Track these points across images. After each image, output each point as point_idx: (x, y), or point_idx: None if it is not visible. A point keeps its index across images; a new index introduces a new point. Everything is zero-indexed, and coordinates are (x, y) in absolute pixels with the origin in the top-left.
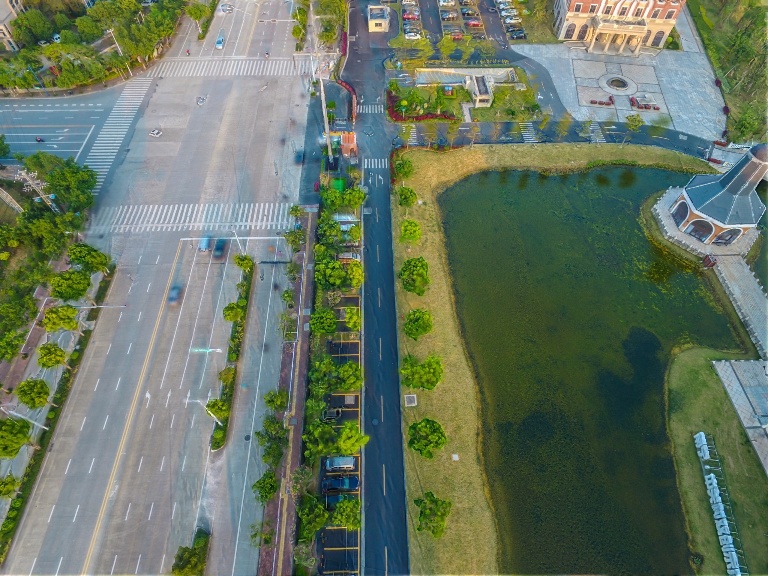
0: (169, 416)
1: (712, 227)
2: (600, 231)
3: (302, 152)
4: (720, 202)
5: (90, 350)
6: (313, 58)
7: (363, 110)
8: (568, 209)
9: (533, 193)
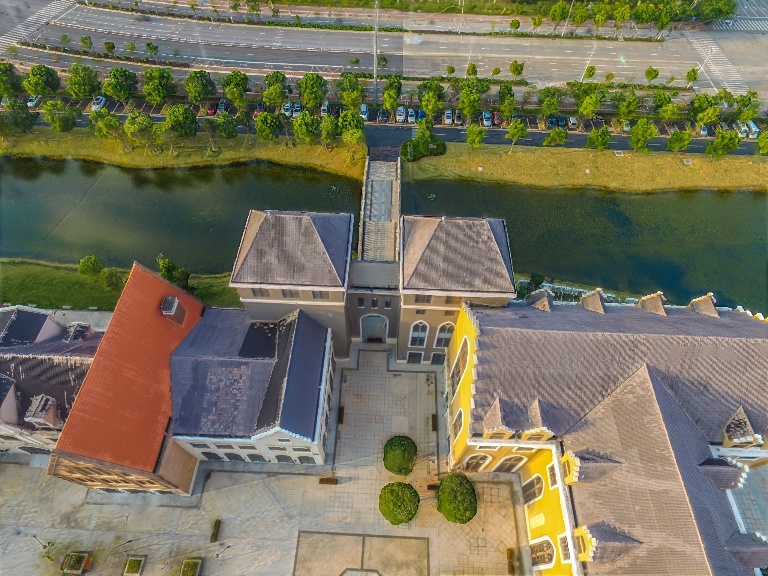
0: (579, 69)
1: None
2: None
3: None
4: None
5: (606, 42)
6: None
7: None
8: None
9: None
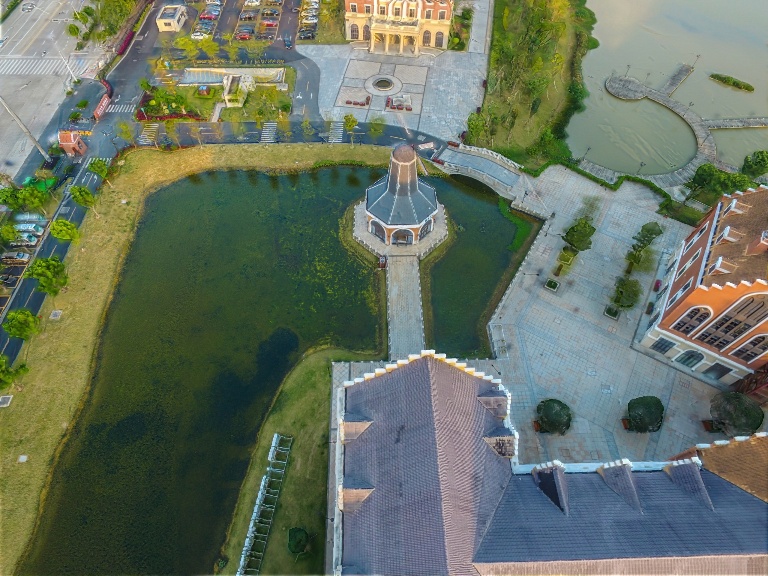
0: None
1: (383, 228)
2: (296, 231)
3: (29, 151)
4: (384, 202)
5: None
6: (89, 57)
7: (113, 109)
8: (274, 209)
9: (247, 193)
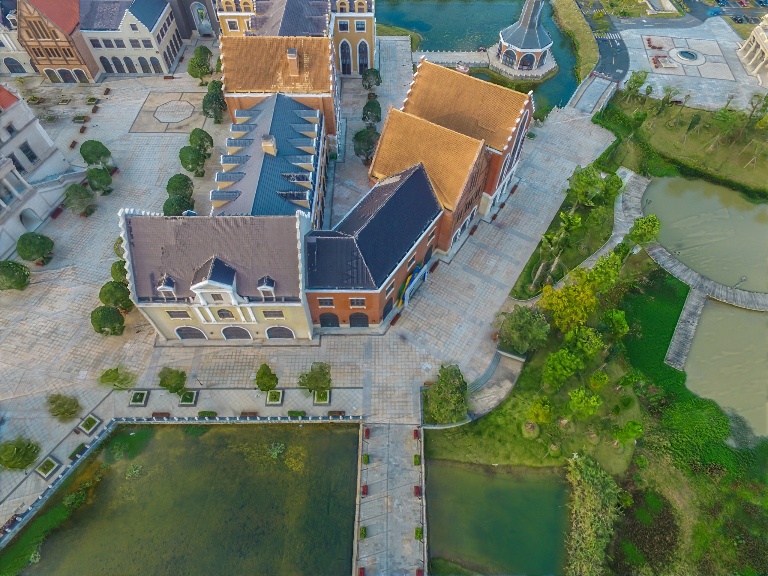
0: None
1: None
2: None
3: None
4: None
5: None
6: None
7: None
8: None
9: None
